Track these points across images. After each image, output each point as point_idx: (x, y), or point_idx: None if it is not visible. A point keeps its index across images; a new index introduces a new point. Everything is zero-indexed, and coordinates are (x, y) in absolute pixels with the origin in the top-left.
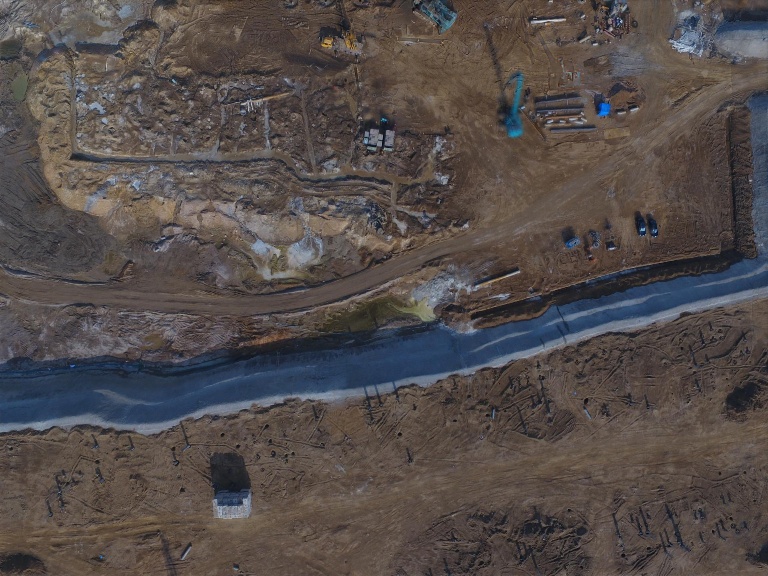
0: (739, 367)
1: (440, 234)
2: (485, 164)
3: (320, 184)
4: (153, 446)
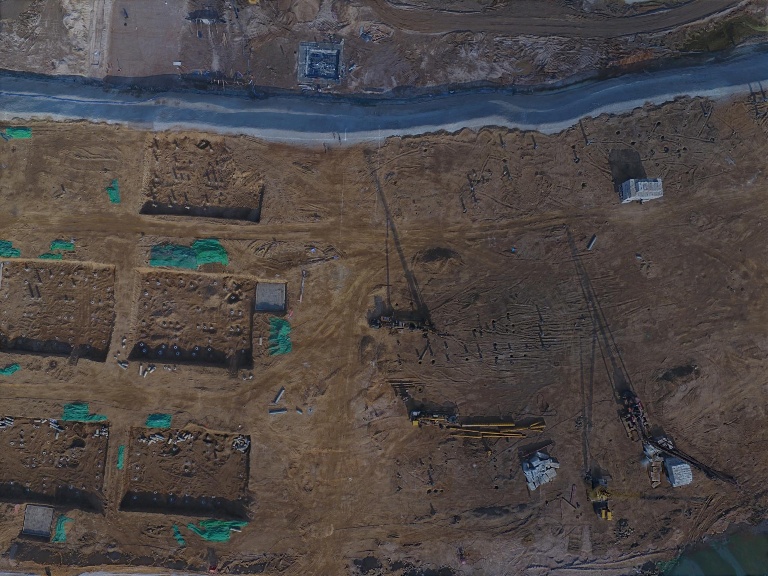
0: None
1: None
2: None
3: None
4: (555, 145)
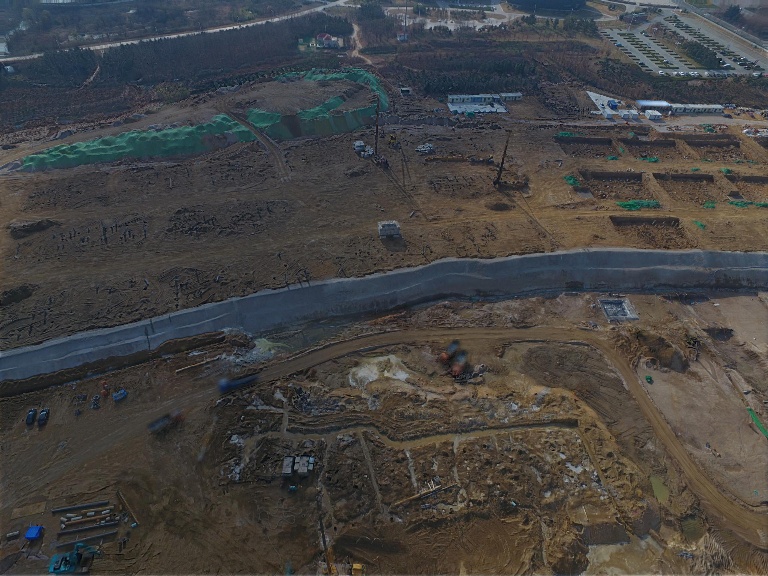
0: (8, 314)
1: (244, 392)
2: (190, 459)
3: (354, 422)
4: (444, 253)
